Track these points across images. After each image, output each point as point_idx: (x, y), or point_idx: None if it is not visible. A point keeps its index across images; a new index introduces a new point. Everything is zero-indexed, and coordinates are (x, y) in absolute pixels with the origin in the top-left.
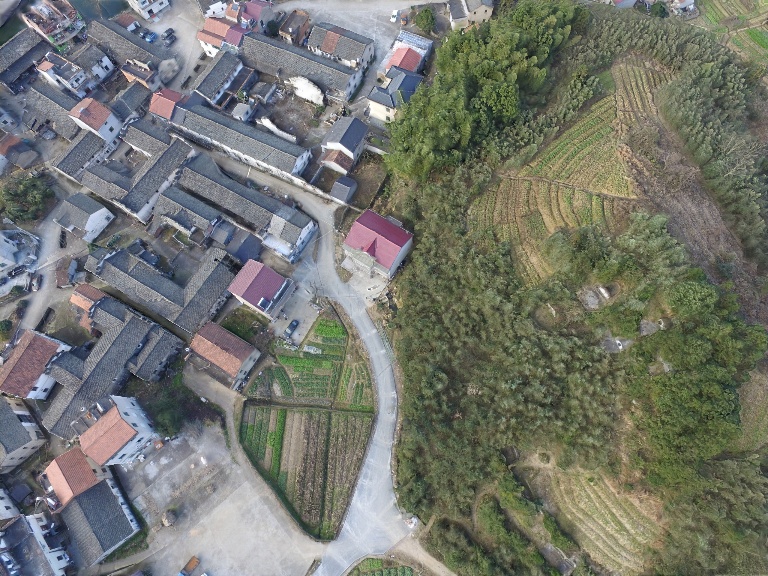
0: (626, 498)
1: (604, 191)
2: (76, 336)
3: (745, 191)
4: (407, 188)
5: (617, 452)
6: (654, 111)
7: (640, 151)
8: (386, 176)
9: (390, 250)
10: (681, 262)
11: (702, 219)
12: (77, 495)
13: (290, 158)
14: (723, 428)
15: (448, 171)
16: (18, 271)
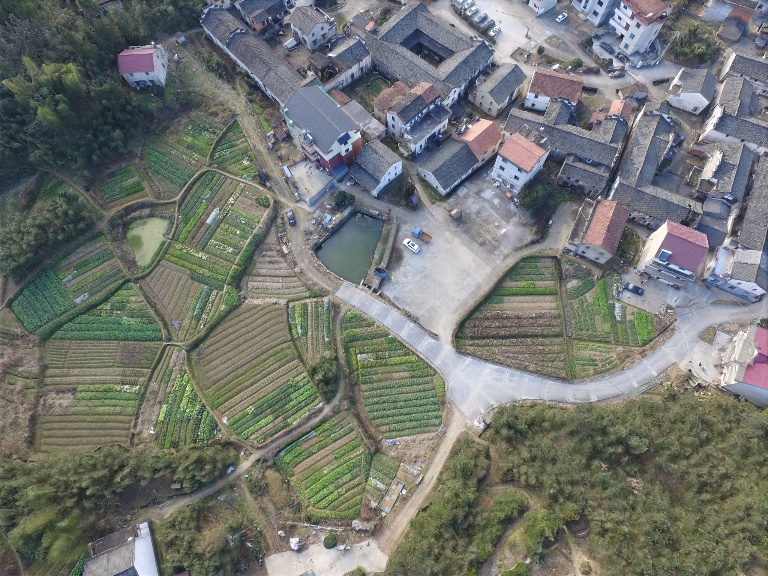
0: None
1: None
2: (579, 114)
3: None
4: None
5: None
6: None
7: None
8: None
9: None
10: None
11: None
12: (468, 145)
13: None
14: None
15: None
16: (624, 58)
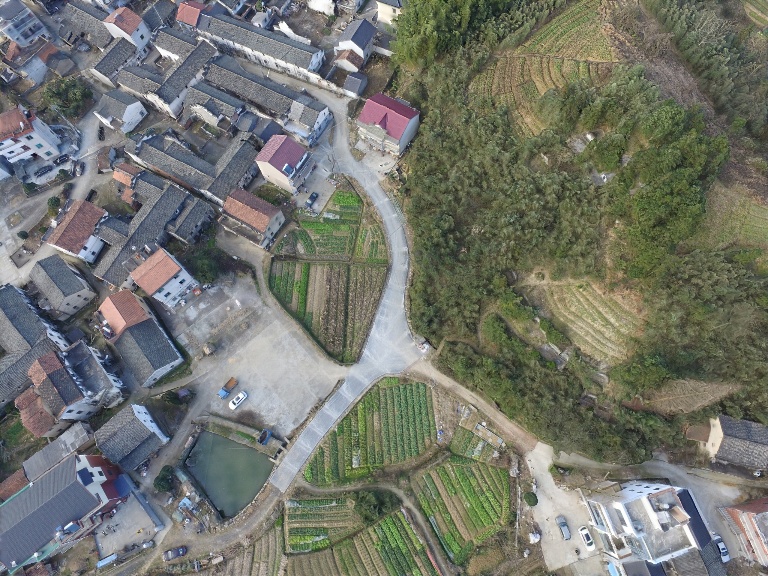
0: (611, 298)
1: (590, 59)
2: (118, 211)
3: (716, 57)
4: (413, 77)
5: (602, 260)
6: (636, 1)
7: (622, 28)
8: (394, 72)
9: (400, 123)
10: (656, 100)
11: (677, 80)
12: (129, 327)
13: (306, 55)
14: (690, 211)
15: (450, 54)
16: (63, 159)
